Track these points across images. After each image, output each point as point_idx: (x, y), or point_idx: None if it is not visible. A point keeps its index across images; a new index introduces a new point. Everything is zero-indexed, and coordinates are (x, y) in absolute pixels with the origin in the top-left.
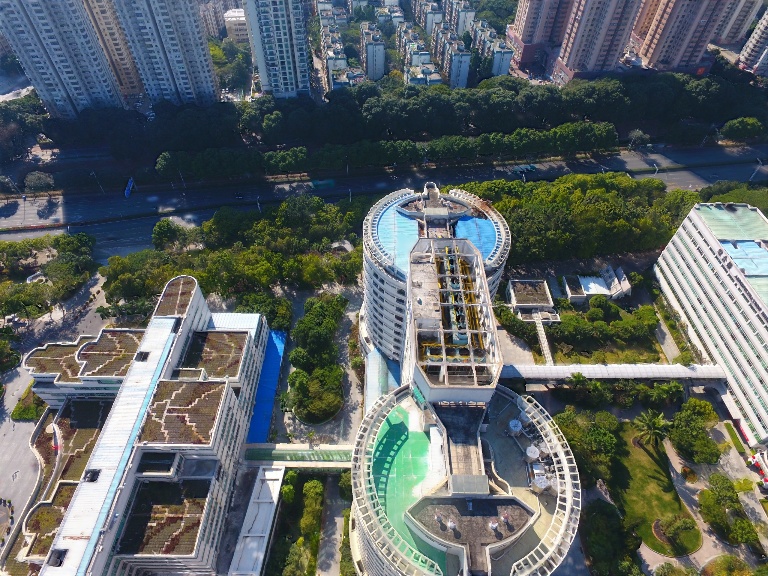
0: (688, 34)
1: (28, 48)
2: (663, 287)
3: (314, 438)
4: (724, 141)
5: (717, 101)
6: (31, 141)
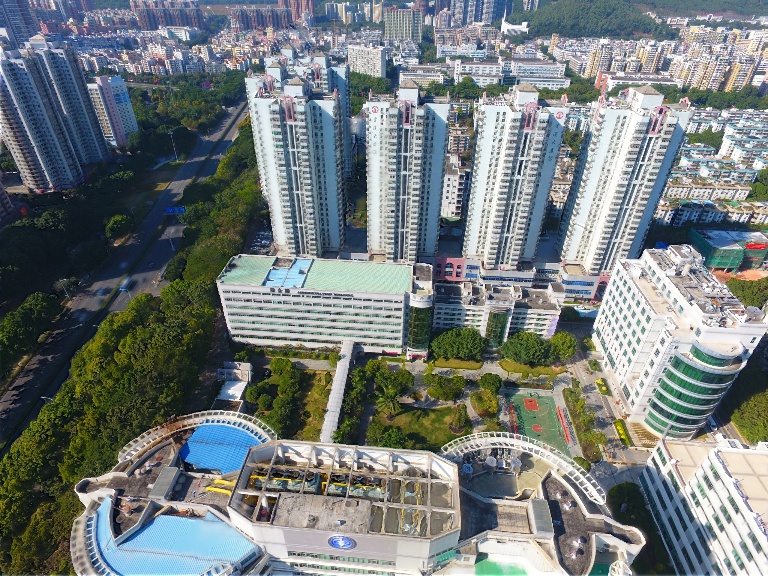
0: None
1: None
2: (257, 343)
3: None
4: (117, 242)
5: (74, 222)
6: None
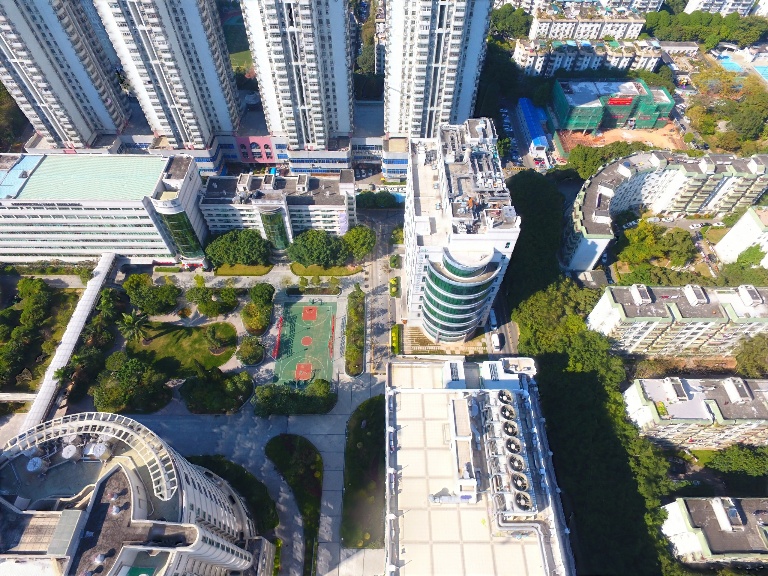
0: None
1: None
2: (6, 261)
3: None
4: None
5: None
6: None
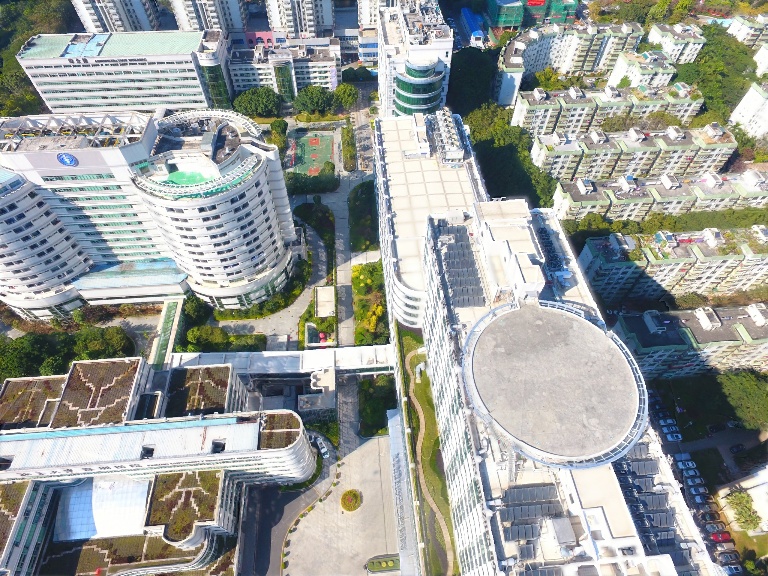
0: None
1: None
2: None
3: (148, 352)
4: None
5: None
6: None
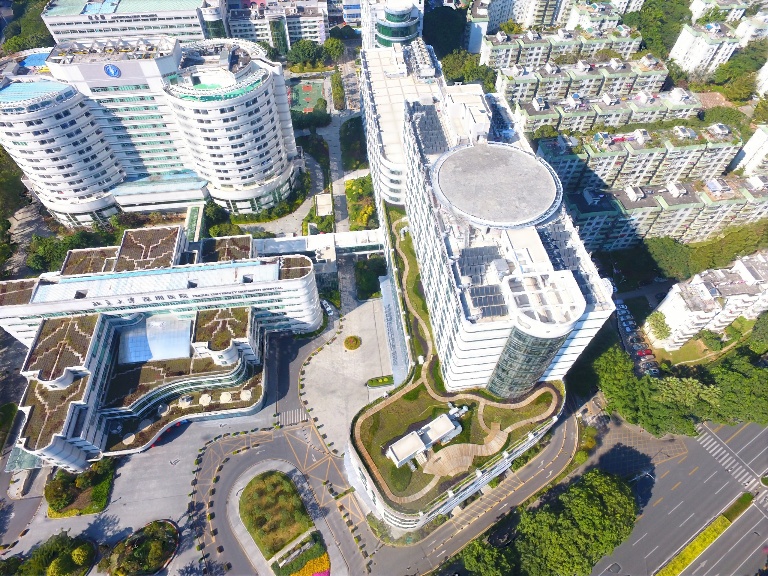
0: None
1: None
2: None
3: None
4: None
5: None
6: None
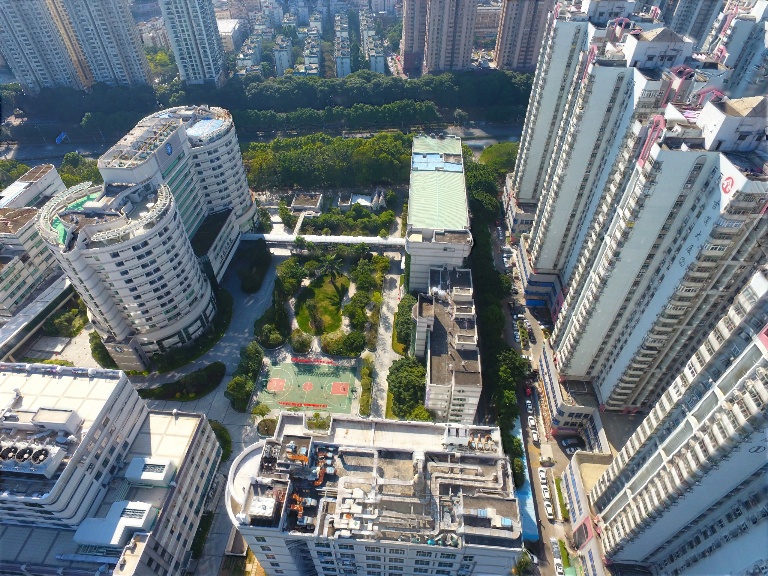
0: (518, 41)
1: (7, 43)
2: None
3: None
4: None
5: None
6: (10, 113)
